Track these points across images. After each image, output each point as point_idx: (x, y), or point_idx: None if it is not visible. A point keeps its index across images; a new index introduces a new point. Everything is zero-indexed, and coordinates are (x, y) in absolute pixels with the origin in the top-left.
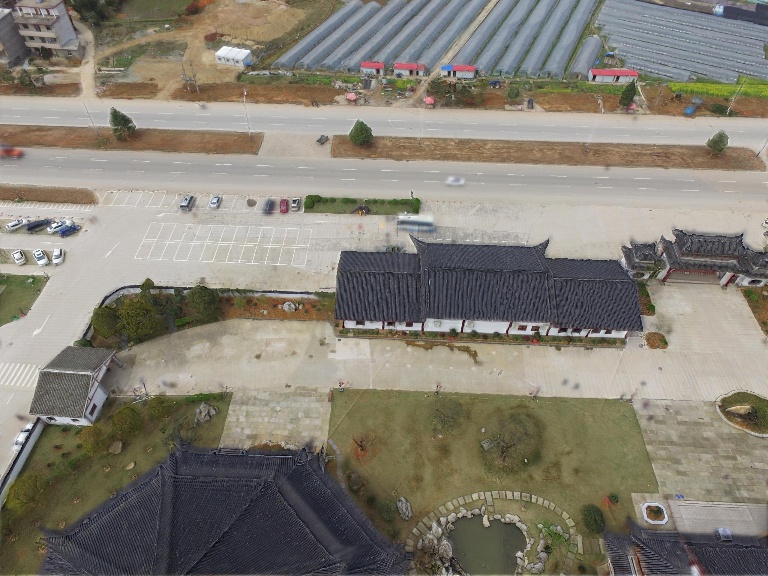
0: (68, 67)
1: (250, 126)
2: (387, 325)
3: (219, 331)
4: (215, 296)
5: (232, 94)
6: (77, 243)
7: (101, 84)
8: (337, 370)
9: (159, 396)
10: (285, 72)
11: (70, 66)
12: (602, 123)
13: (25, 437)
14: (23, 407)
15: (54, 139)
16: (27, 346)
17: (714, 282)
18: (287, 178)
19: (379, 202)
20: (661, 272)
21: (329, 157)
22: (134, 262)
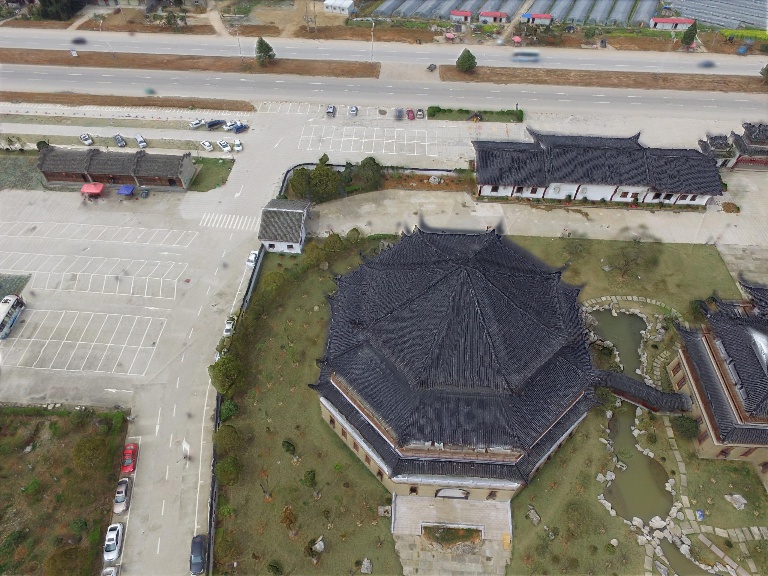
0: (196, 13)
1: (367, 58)
2: (515, 192)
3: (380, 197)
4: (379, 168)
5: (345, 34)
6: (249, 138)
7: (230, 26)
8: (480, 223)
9: (345, 237)
10: (385, 18)
11: (197, 13)
12: (667, 59)
13: (254, 257)
14: (243, 242)
15: (206, 65)
16: (233, 204)
17: None
18: (408, 95)
19: (489, 113)
20: (731, 161)
21: (439, 81)
22: (298, 151)
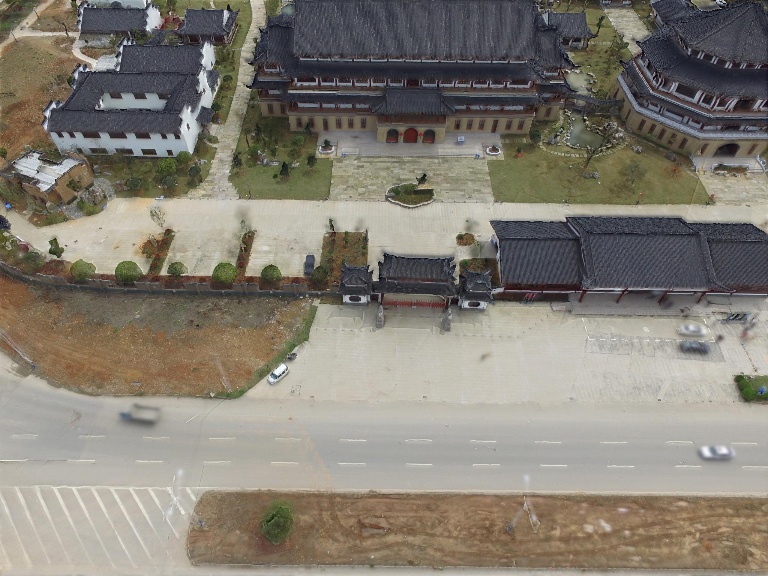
0: None
1: None
2: None
3: None
4: None
5: None
6: None
7: None
8: (719, 215)
9: None
10: None
11: None
12: None
13: None
14: None
15: None
16: None
17: (389, 294)
18: None
19: None
20: None
21: None
22: None
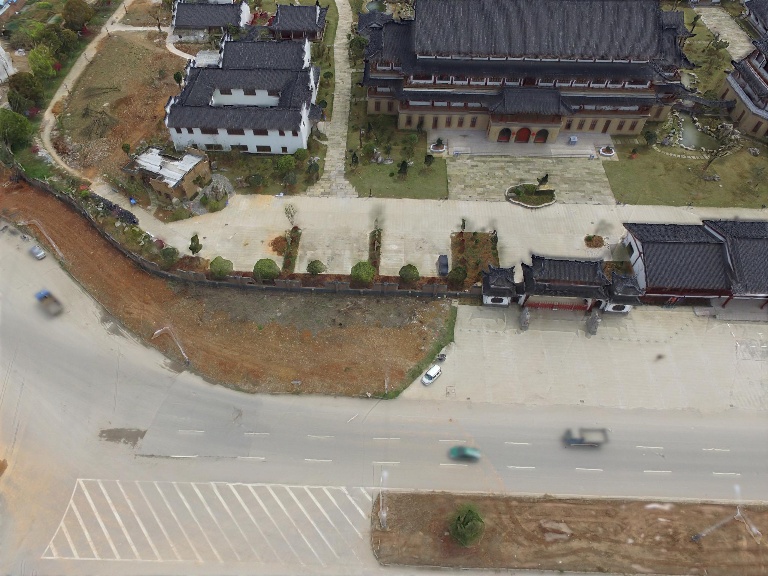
0: None
1: None
2: None
3: None
4: None
5: None
6: None
7: None
8: None
9: None
10: None
11: None
12: None
13: None
14: None
15: None
16: None
17: None
18: None
19: None
20: None
21: None
22: None
